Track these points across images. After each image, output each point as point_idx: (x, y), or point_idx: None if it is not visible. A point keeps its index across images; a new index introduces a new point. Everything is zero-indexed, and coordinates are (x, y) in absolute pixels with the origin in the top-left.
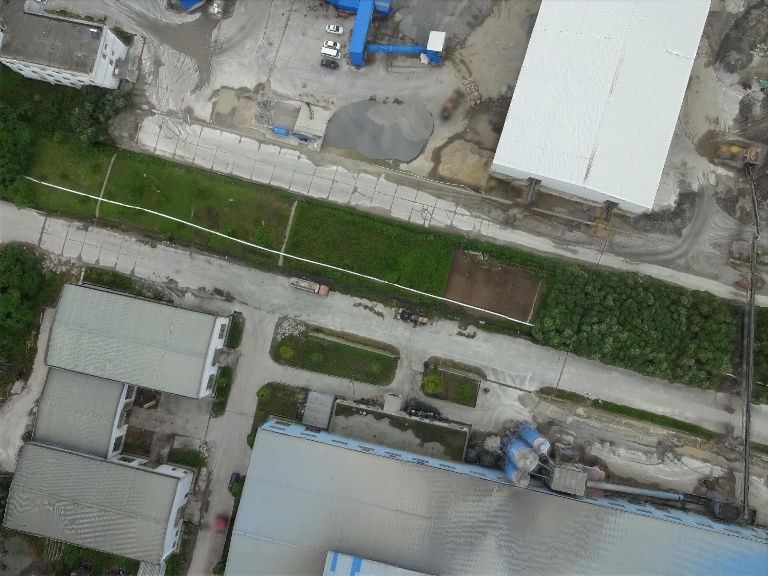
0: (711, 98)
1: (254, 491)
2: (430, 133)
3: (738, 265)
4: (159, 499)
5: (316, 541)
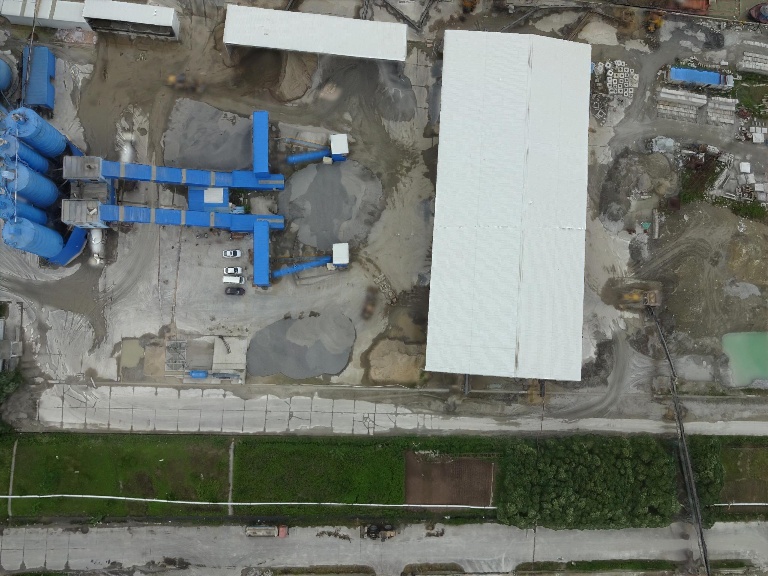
0: (604, 248)
1: None
2: (353, 339)
3: (662, 399)
4: None
5: None
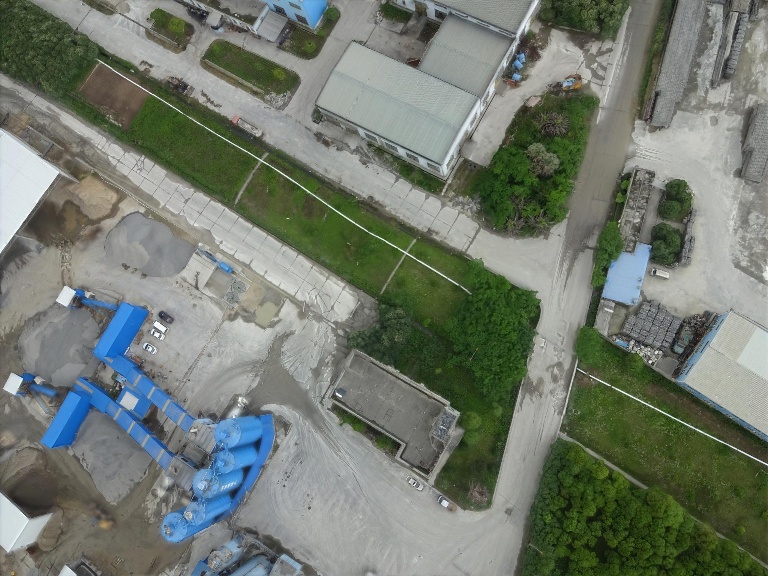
0: None
1: None
2: None
3: None
4: None
5: None
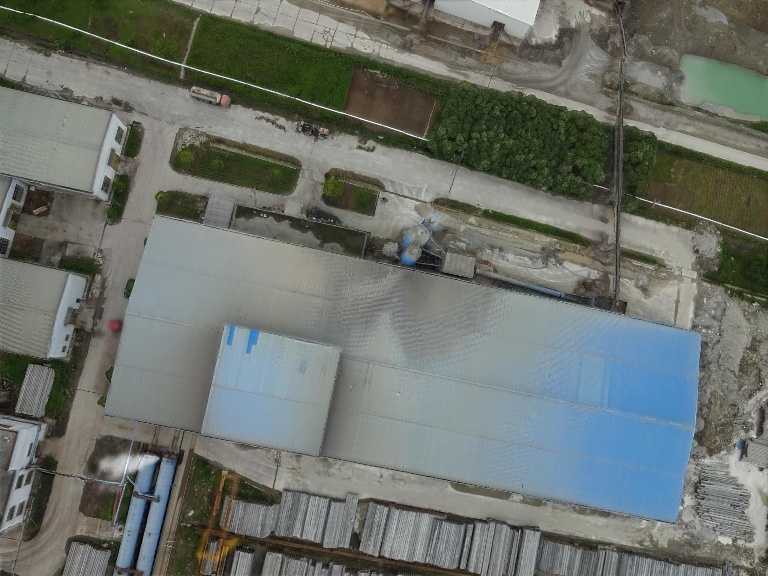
0: None
1: (149, 274)
2: None
3: (610, 93)
4: (47, 291)
5: (213, 320)
